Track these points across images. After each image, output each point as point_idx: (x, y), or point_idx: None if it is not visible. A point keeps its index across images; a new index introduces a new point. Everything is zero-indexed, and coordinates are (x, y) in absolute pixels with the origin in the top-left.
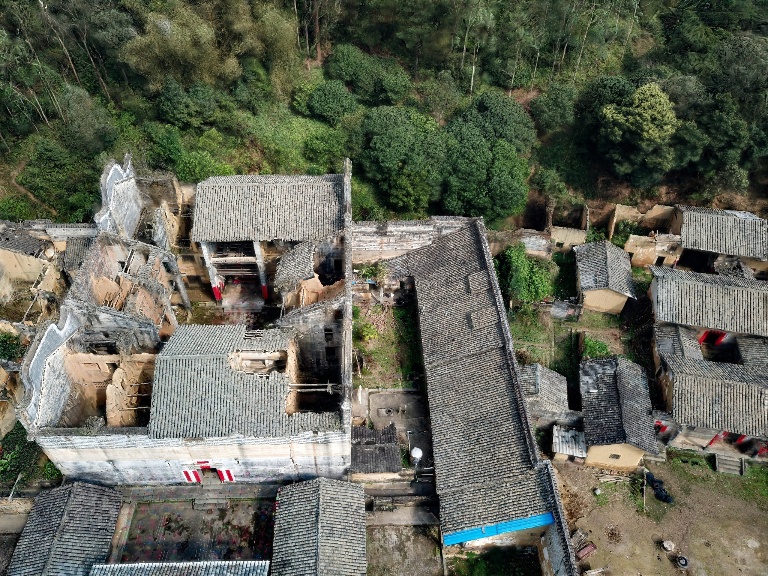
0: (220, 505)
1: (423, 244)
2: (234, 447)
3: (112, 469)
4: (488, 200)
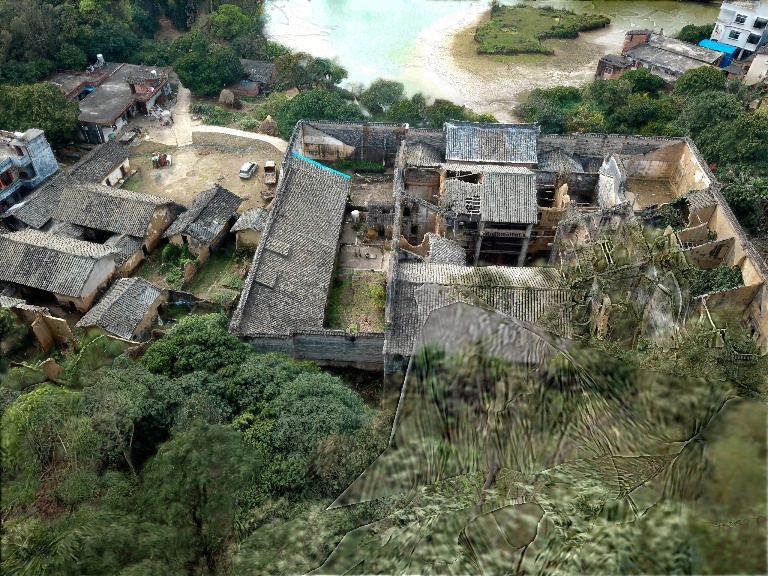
0: None
1: None
2: None
3: None
4: None
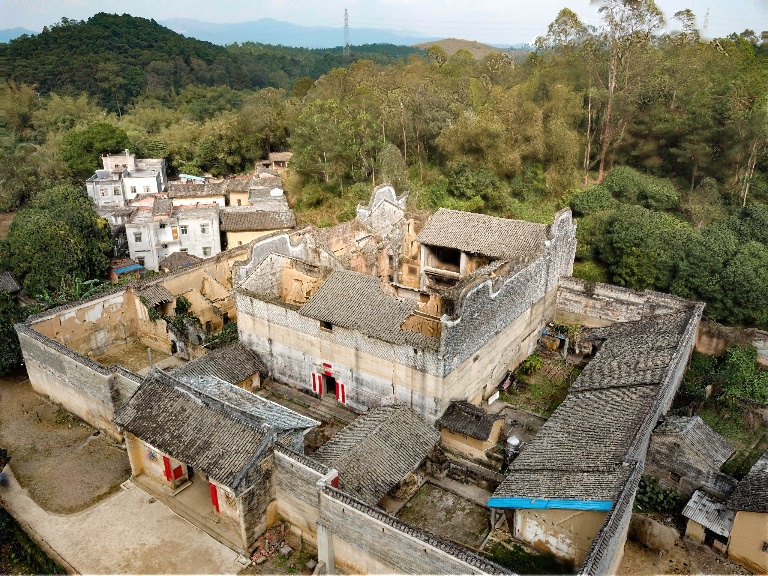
0: (325, 418)
1: (630, 318)
2: (352, 352)
3: (269, 352)
4: (718, 289)
